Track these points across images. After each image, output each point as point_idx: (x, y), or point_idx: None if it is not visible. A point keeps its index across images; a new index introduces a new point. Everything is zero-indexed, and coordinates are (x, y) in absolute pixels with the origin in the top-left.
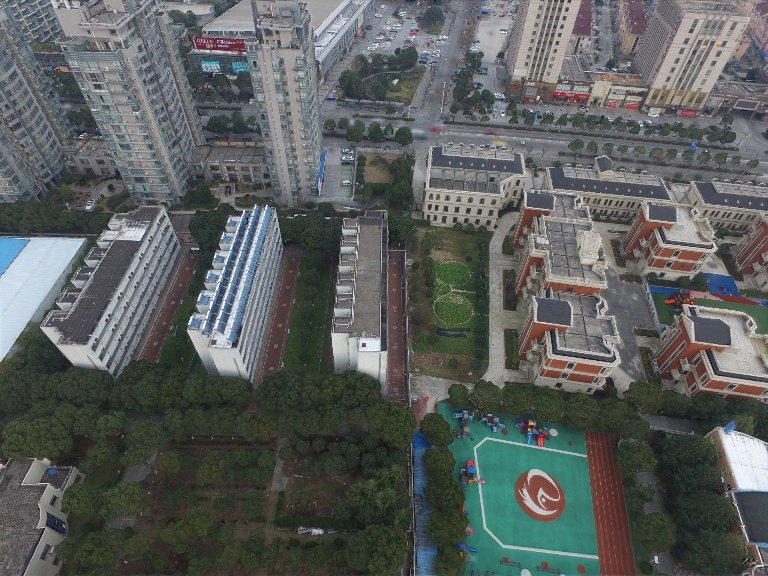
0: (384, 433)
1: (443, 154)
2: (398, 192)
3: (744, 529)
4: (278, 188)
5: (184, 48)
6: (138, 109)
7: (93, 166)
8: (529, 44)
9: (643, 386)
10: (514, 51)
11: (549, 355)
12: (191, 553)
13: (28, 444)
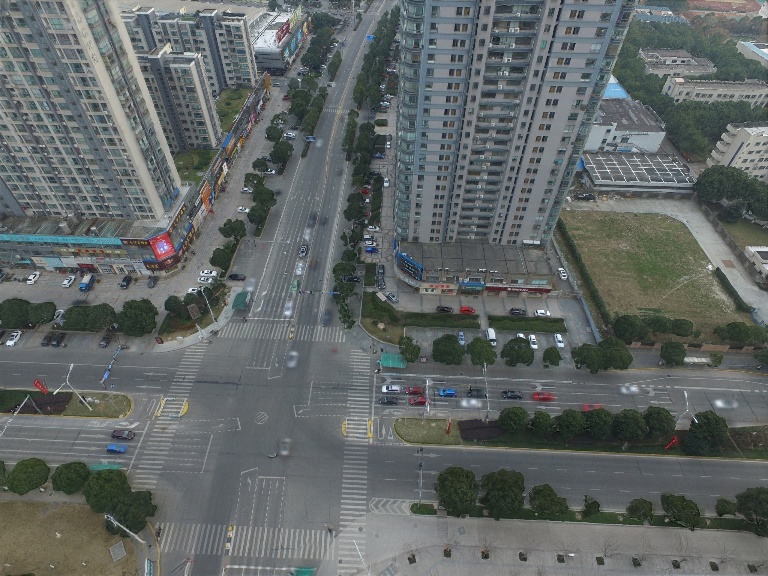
0: None
1: None
2: None
3: None
4: None
5: None
6: None
7: None
8: None
9: None
10: None
11: None
12: None
13: None
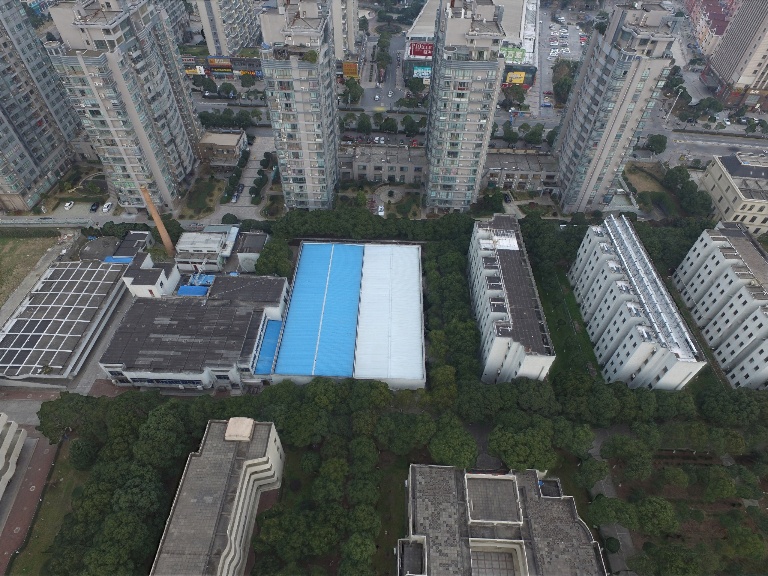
0: None
1: (743, 164)
2: (701, 202)
3: None
4: (576, 196)
5: (385, 54)
6: (486, 118)
7: (368, 172)
8: (765, 52)
9: None
10: (739, 59)
11: None
12: (742, 571)
13: (535, 456)
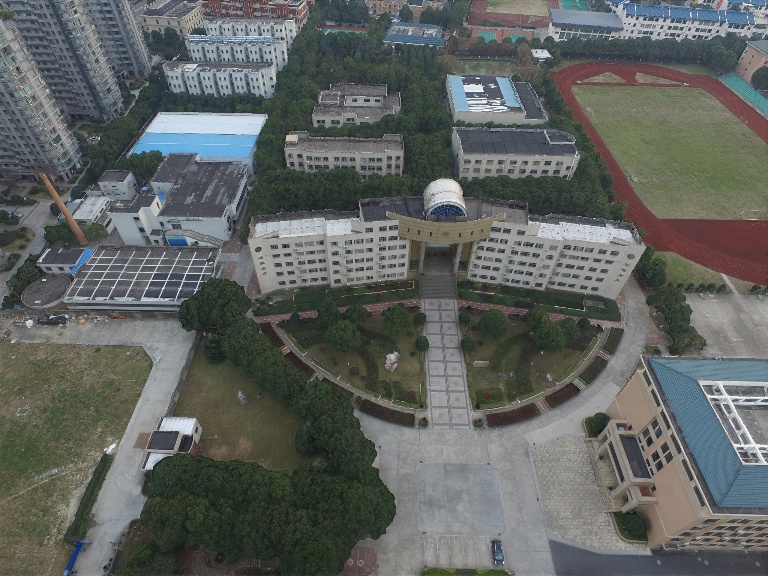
0: (321, 36)
1: (157, 8)
2: (173, 32)
3: (358, 1)
4: (143, 61)
5: None
6: (92, 23)
7: None
8: None
9: (312, 6)
10: None
11: (299, 8)
12: None
13: None
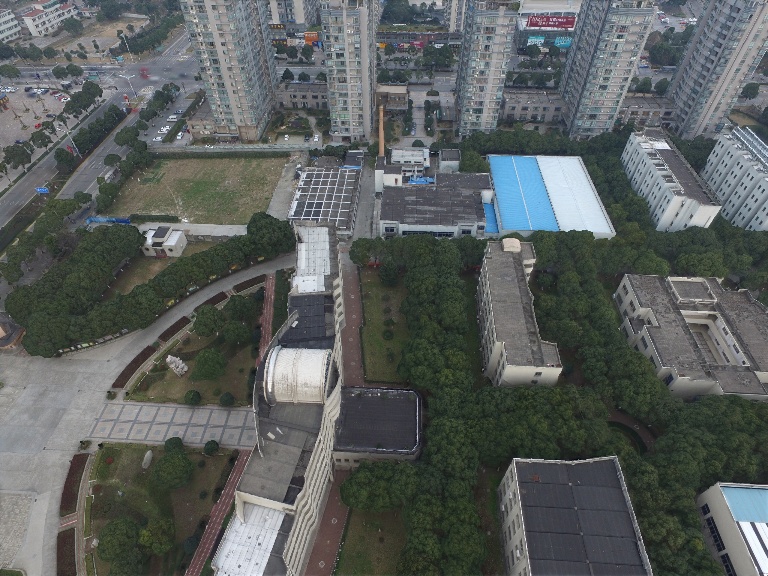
0: None
1: None
2: None
3: None
4: (694, 125)
5: None
6: (636, 55)
7: (516, 112)
8: None
9: None
10: None
11: None
12: None
13: (716, 266)
